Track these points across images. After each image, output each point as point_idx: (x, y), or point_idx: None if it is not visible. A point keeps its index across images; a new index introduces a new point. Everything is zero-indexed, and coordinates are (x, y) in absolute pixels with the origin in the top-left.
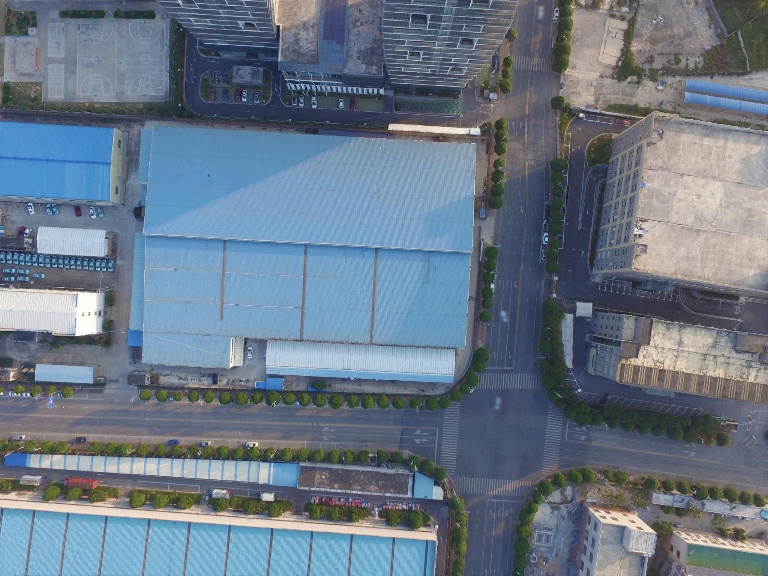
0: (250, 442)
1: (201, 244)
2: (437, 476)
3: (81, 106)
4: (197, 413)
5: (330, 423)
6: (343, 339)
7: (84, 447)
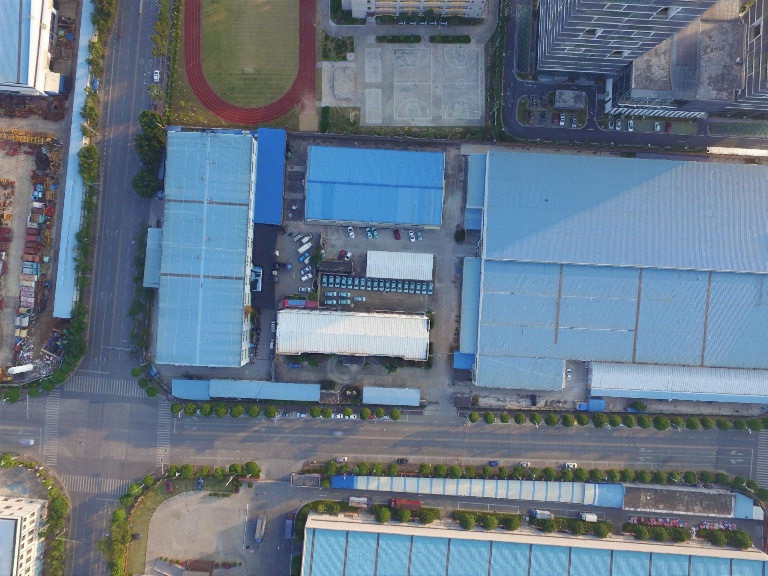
0: (569, 463)
1: (538, 268)
2: (764, 497)
3: (399, 130)
4: (516, 434)
5: (647, 444)
6: (674, 361)
7: (405, 469)
